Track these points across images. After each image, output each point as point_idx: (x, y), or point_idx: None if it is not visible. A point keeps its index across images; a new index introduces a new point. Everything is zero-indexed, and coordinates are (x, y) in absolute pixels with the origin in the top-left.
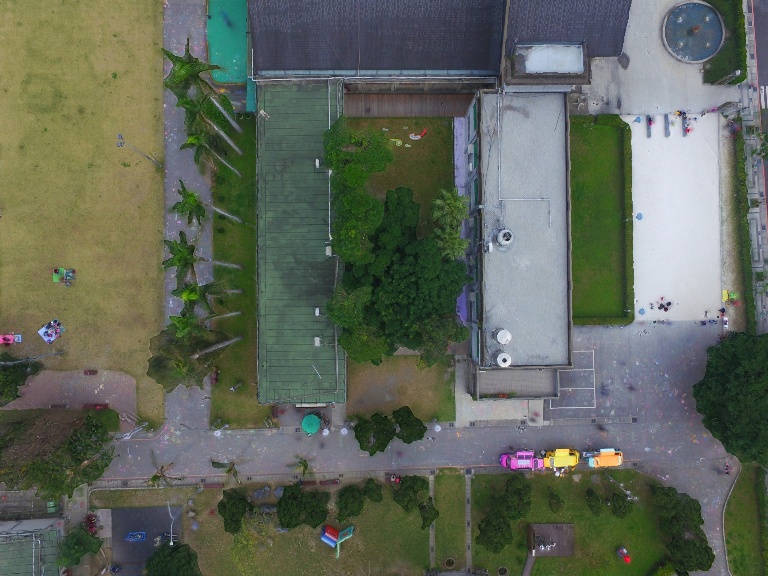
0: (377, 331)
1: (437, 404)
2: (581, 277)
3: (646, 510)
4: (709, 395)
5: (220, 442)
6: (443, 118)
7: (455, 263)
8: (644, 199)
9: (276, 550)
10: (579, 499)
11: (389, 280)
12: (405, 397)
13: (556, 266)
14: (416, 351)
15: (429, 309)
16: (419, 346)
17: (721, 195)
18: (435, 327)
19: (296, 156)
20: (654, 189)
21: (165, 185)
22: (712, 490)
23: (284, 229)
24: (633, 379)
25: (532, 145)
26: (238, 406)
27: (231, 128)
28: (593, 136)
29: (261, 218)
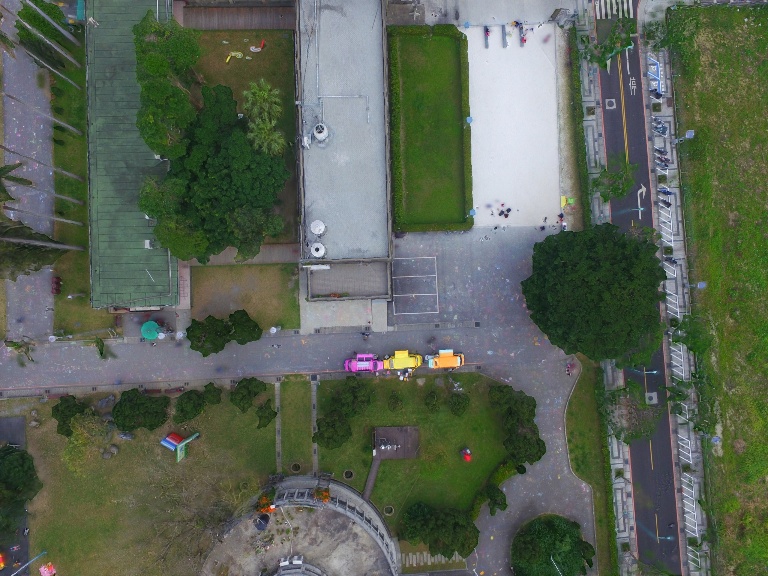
0: (196, 226)
1: (281, 312)
2: (422, 185)
3: (489, 411)
4: (532, 288)
5: (64, 353)
6: (283, 31)
7: (269, 156)
8: (483, 108)
9: (121, 458)
10: (423, 402)
11: (203, 173)
12: (250, 306)
13: (375, 161)
14: (259, 260)
15: (242, 201)
16: (237, 240)
17: (558, 103)
18: (241, 214)
19: (126, 63)
20: (493, 99)
21: (4, 99)
22: (554, 391)
23: (115, 135)
24: (475, 284)
25: (350, 43)
26: (82, 317)
27: (65, 39)
28: (432, 47)
29: (92, 124)
